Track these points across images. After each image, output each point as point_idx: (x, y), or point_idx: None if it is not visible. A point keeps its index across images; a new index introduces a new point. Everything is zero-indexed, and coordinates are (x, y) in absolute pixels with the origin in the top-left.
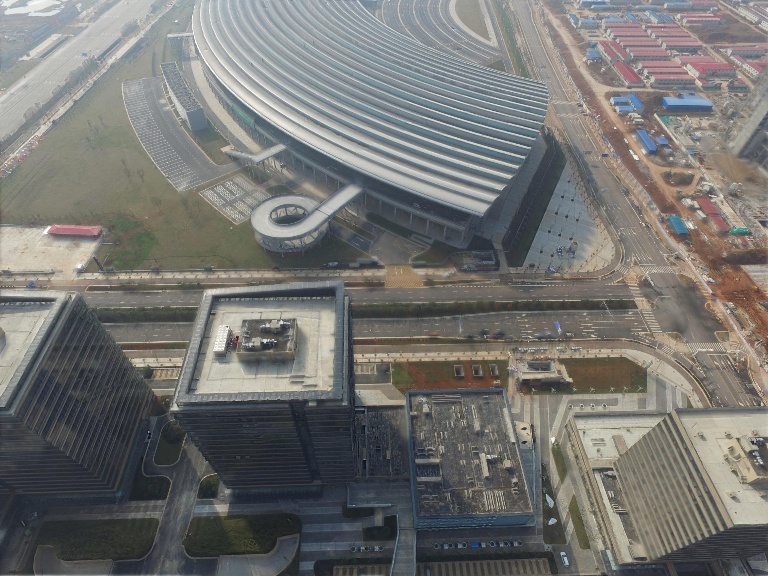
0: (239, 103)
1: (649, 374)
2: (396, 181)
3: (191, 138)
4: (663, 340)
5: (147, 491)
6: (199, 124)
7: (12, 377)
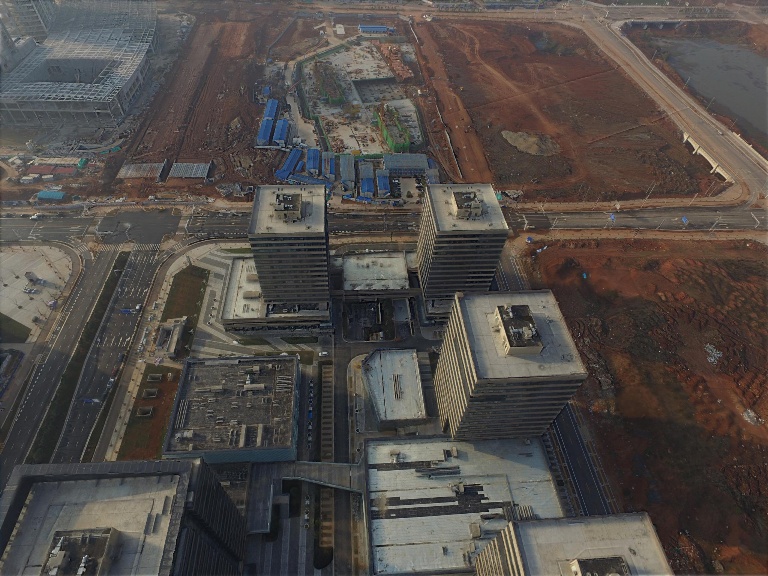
0: None
1: (195, 264)
2: None
3: None
4: (168, 246)
5: None
6: None
7: None
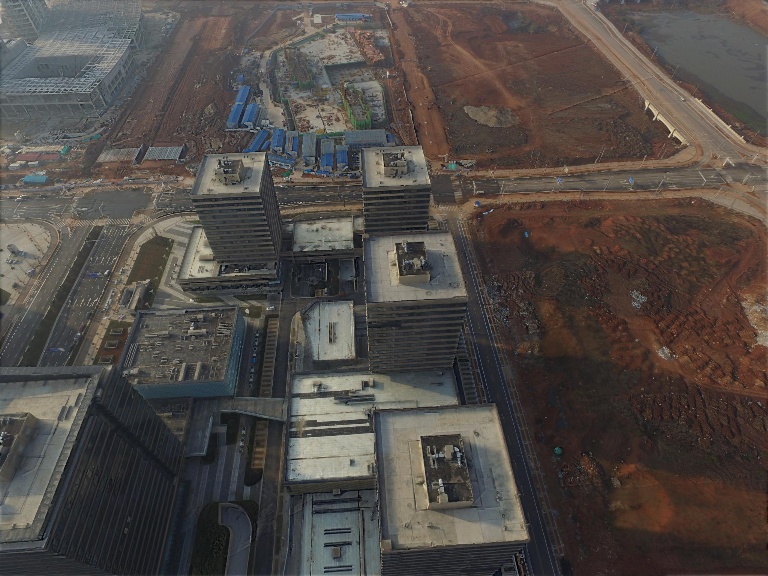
0: None
1: (161, 235)
2: None
3: None
4: (138, 220)
5: None
6: None
7: None
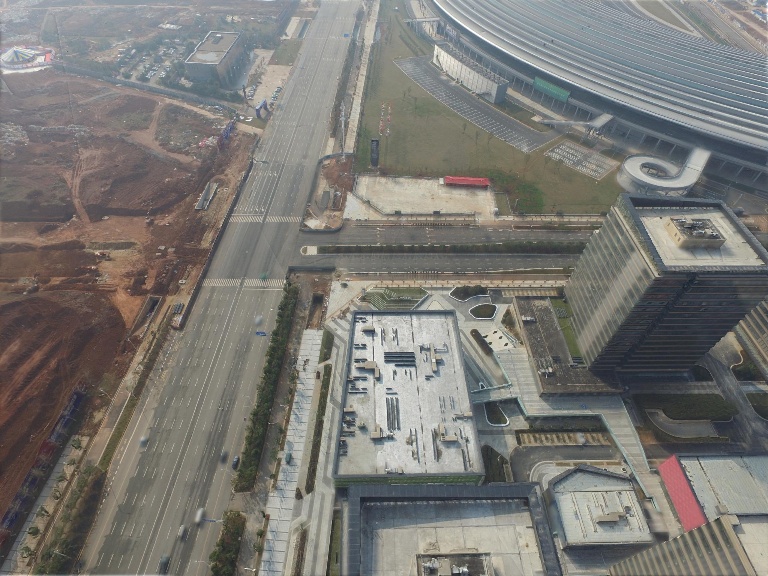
0: (549, 78)
1: None
2: (756, 143)
3: (497, 109)
4: None
5: (699, 374)
6: (500, 97)
7: (763, 253)
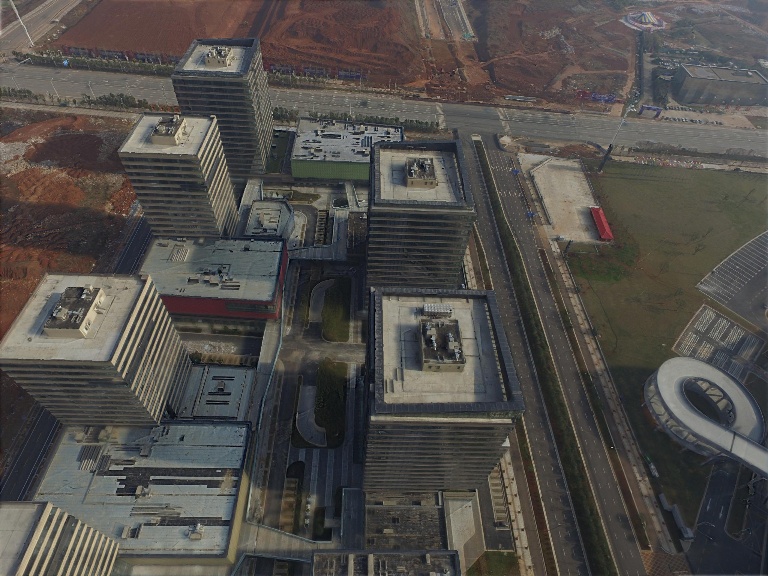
0: None
1: None
2: None
3: None
4: None
5: None
6: None
7: (397, 200)
